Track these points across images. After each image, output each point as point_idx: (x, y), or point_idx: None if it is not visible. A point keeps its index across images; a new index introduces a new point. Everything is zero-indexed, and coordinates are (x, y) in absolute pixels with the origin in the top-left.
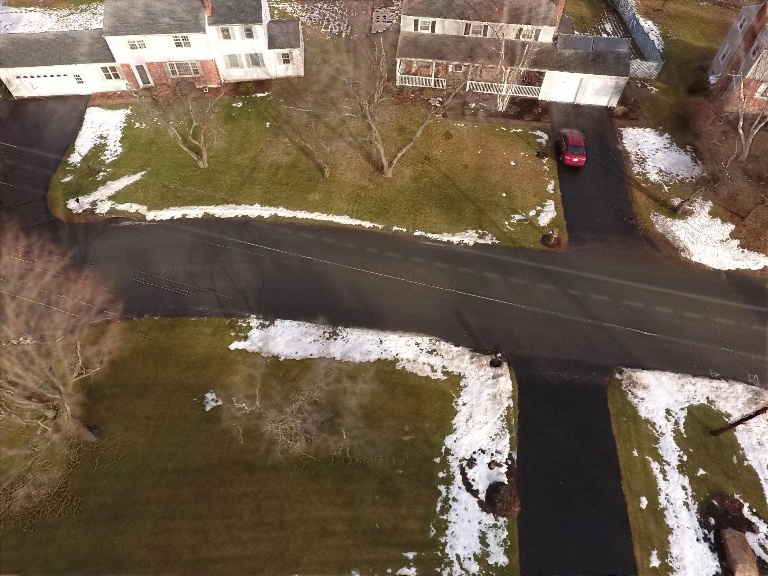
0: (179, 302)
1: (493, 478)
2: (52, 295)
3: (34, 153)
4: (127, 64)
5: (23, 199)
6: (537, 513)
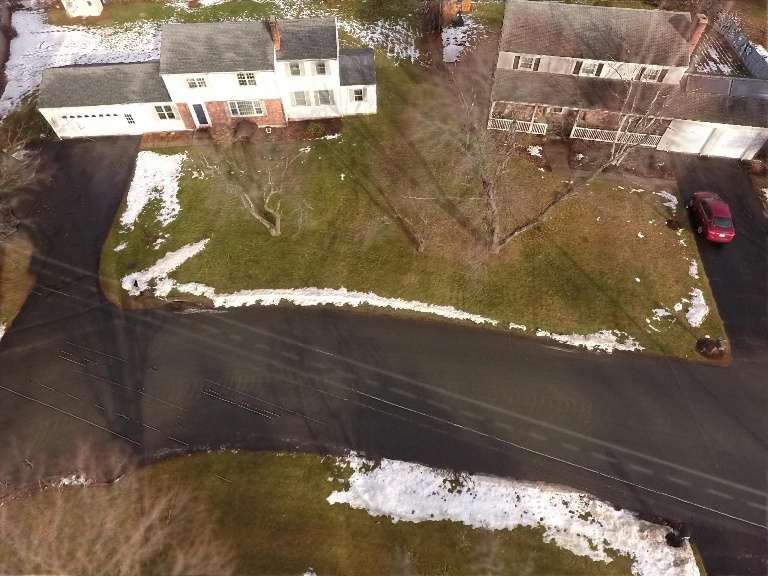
0: (261, 428)
1: None
2: (109, 413)
3: (82, 210)
4: (184, 103)
5: (72, 274)
6: None
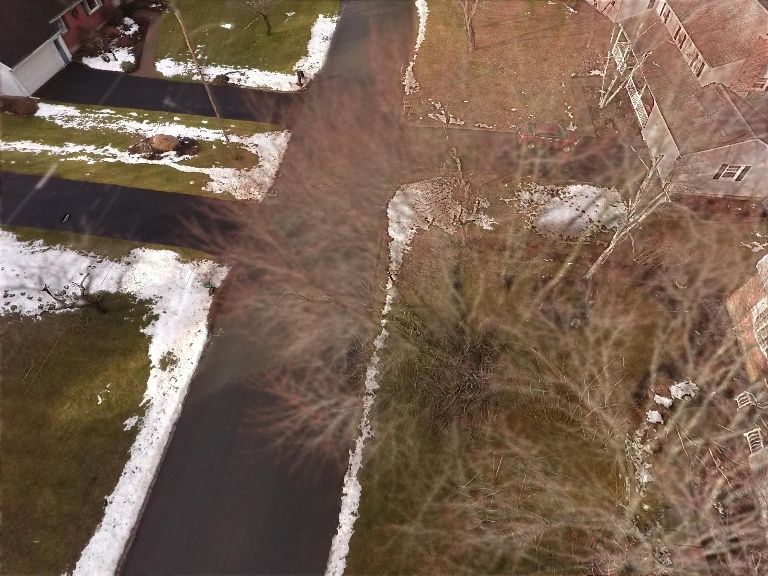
0: None
1: (232, 78)
2: None
3: None
4: None
5: None
6: (211, 90)
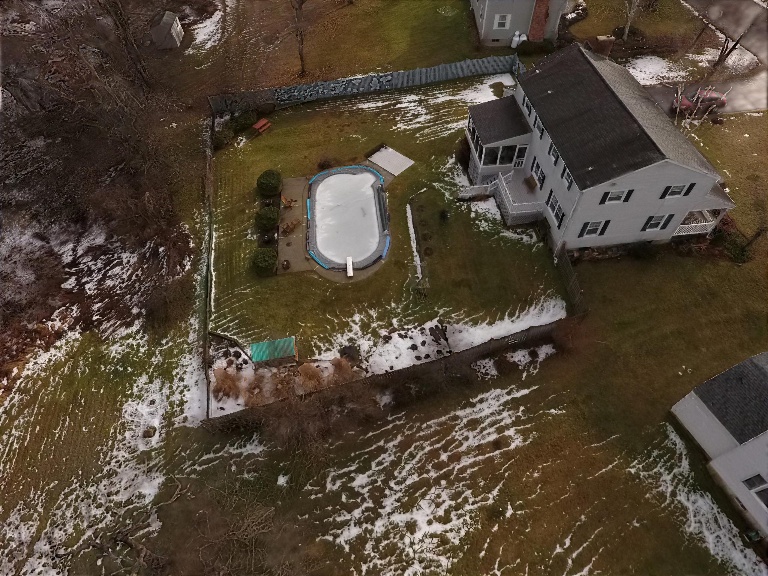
0: None
1: None
2: None
3: None
4: None
5: None
6: None
